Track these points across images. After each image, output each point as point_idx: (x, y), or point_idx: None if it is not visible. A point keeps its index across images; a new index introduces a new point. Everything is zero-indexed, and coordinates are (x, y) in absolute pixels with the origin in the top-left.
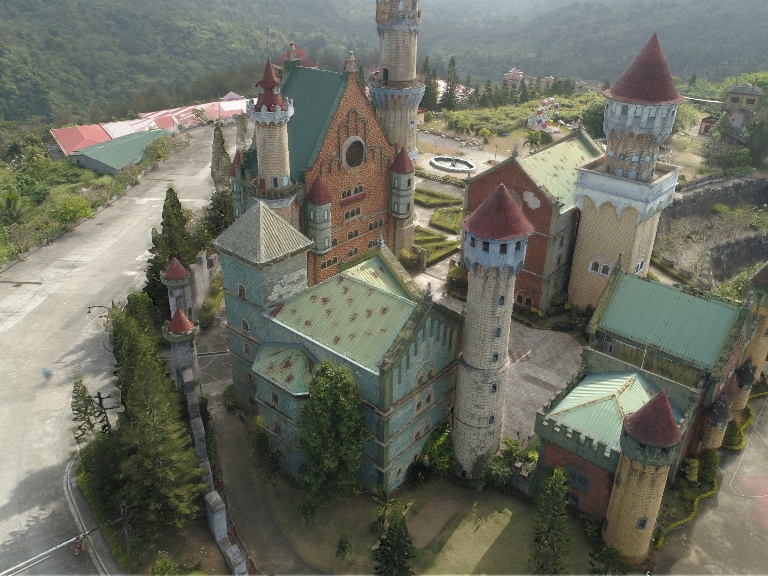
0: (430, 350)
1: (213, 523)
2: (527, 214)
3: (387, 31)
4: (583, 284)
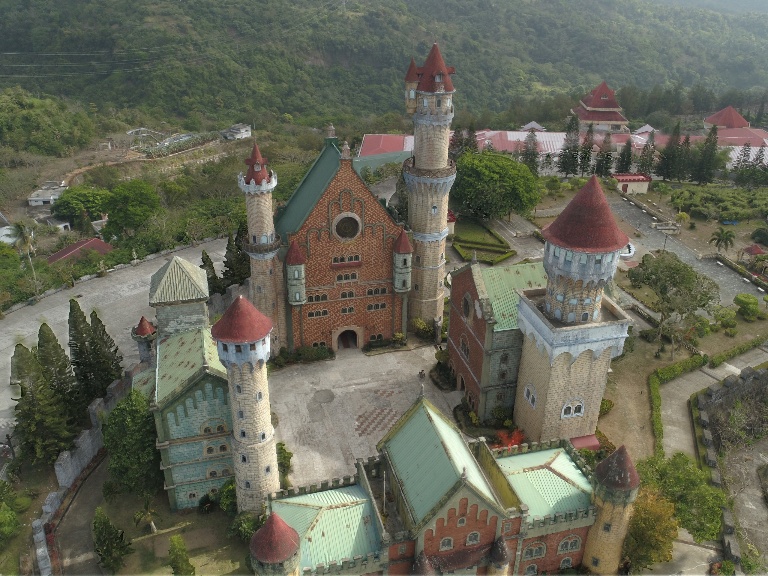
0: (216, 409)
1: (55, 472)
2: (476, 321)
3: None
4: (521, 407)
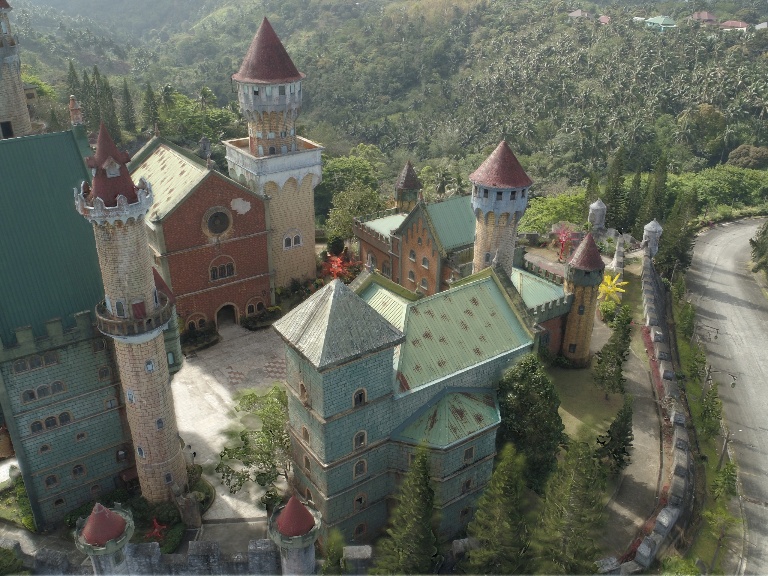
0: None
1: None
2: (239, 222)
3: None
4: (281, 264)
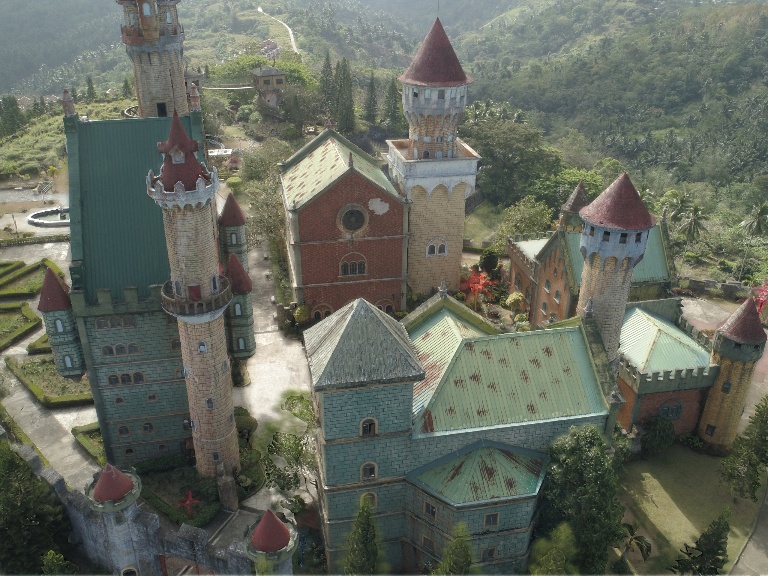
0: None
1: None
2: (375, 222)
3: (156, 53)
4: (422, 271)
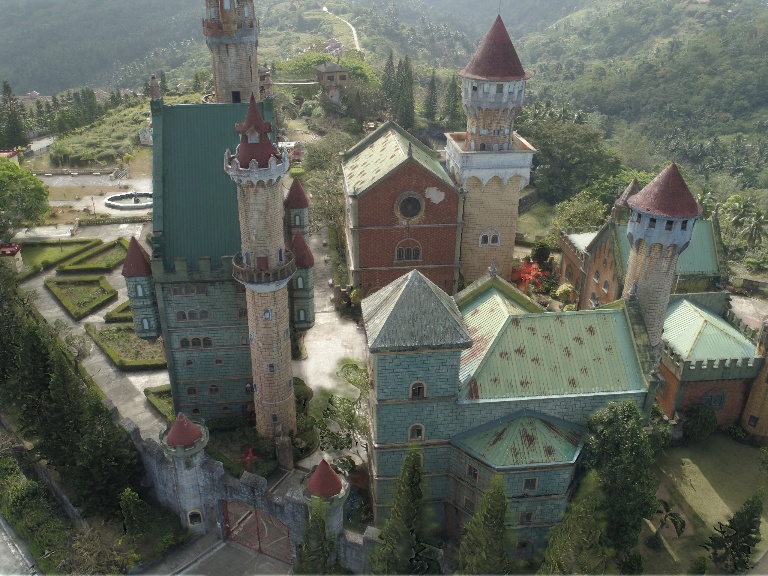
0: None
1: None
2: (431, 210)
3: (233, 45)
4: (475, 260)
